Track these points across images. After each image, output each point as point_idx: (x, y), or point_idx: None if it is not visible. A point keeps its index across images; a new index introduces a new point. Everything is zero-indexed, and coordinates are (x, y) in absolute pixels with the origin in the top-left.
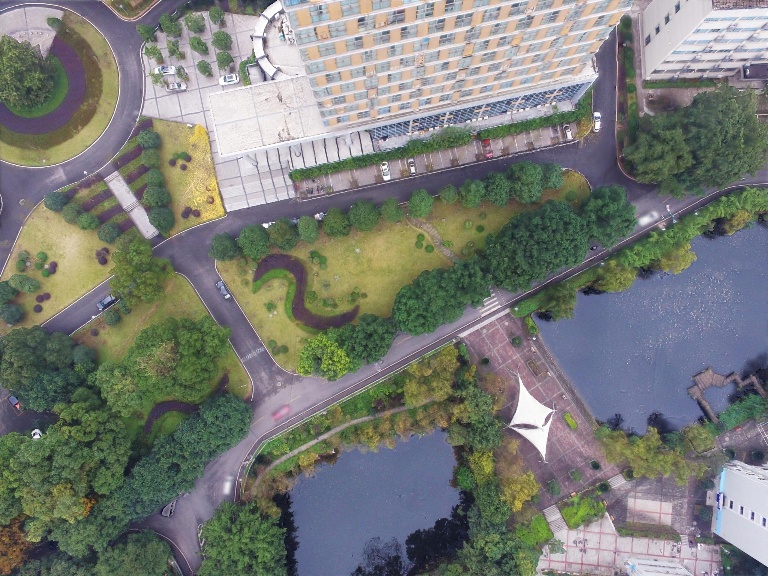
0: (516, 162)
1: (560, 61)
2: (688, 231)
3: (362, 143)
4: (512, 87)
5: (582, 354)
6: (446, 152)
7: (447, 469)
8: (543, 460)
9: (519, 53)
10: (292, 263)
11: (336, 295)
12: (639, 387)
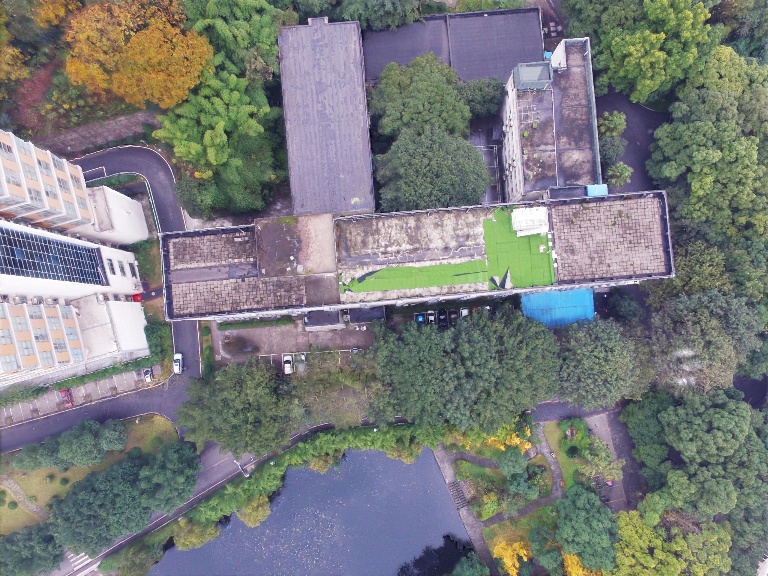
0: (87, 417)
1: None
2: (261, 484)
3: None
4: None
5: None
6: (25, 403)
7: None
8: None
9: None
10: None
11: None
12: None
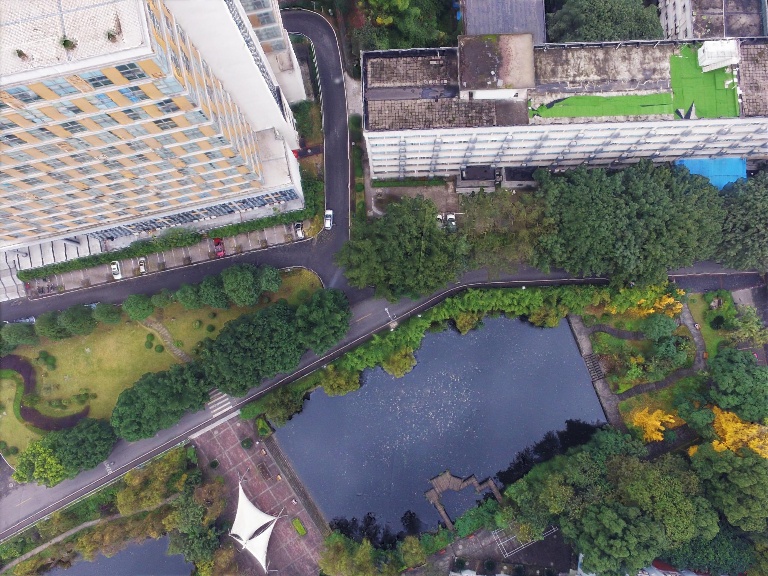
0: (241, 262)
1: (220, 181)
2: (409, 334)
3: (90, 243)
4: (195, 200)
5: (317, 455)
6: (178, 250)
7: (185, 573)
8: (266, 570)
9: (153, 181)
10: (20, 363)
11: (66, 395)
12: (375, 490)
